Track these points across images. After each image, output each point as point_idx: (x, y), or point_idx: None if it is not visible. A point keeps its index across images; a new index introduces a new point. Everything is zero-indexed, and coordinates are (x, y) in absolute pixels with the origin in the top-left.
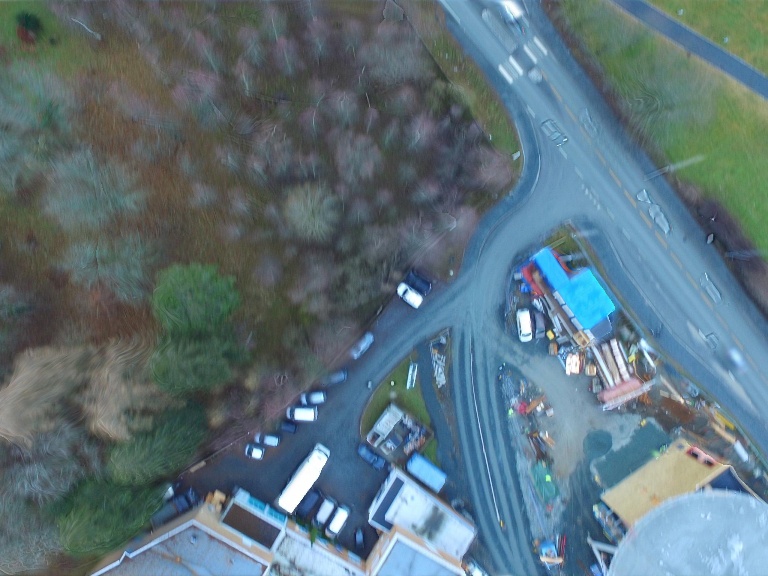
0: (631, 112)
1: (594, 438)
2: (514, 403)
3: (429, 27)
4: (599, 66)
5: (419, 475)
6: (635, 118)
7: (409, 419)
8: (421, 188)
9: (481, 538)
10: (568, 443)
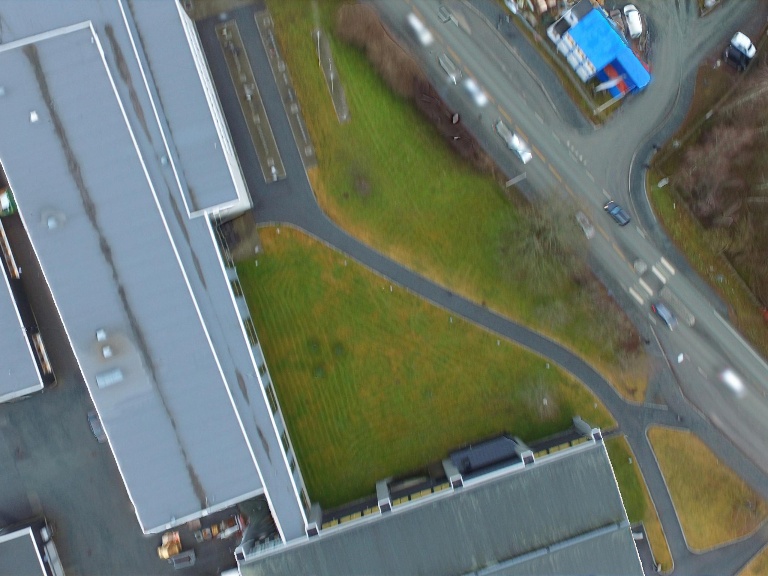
0: (554, 235)
1: None
2: None
3: (741, 305)
4: (582, 280)
5: None
6: (550, 229)
7: None
8: (767, 137)
9: None
10: None
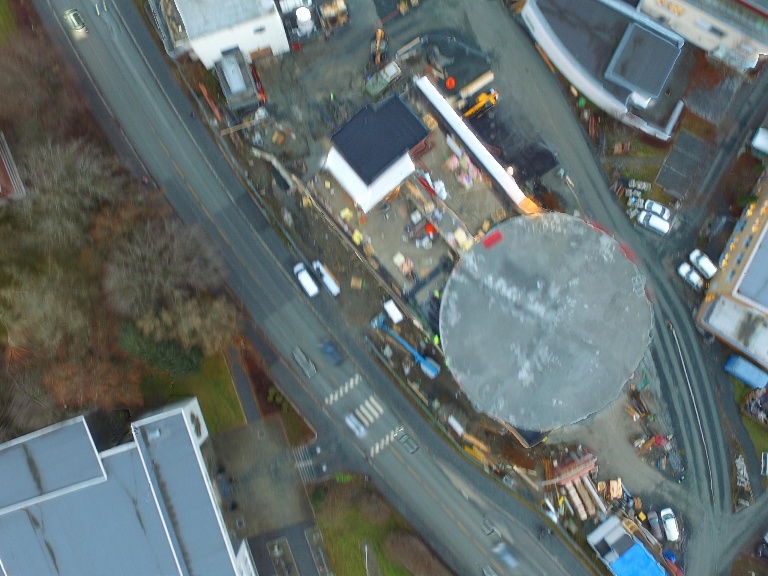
0: None
1: (589, 418)
2: (668, 445)
3: None
4: None
5: (760, 373)
6: None
7: (761, 419)
8: None
9: (688, 310)
10: (612, 409)
